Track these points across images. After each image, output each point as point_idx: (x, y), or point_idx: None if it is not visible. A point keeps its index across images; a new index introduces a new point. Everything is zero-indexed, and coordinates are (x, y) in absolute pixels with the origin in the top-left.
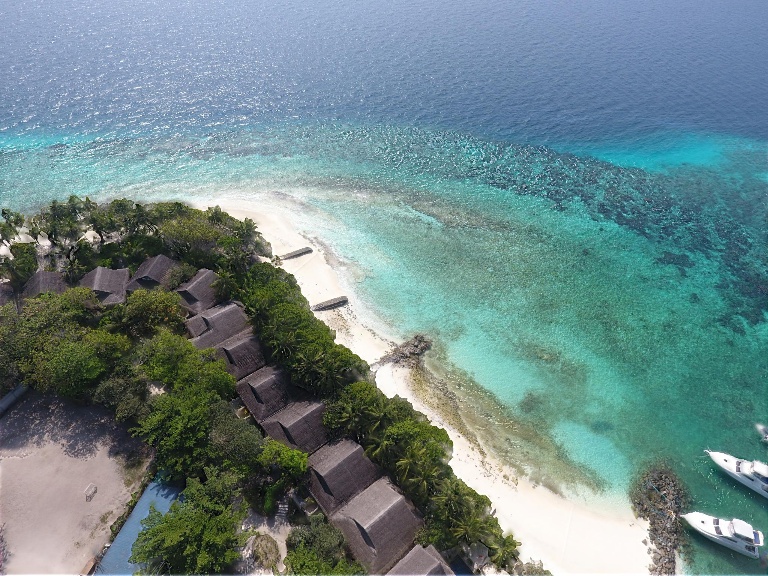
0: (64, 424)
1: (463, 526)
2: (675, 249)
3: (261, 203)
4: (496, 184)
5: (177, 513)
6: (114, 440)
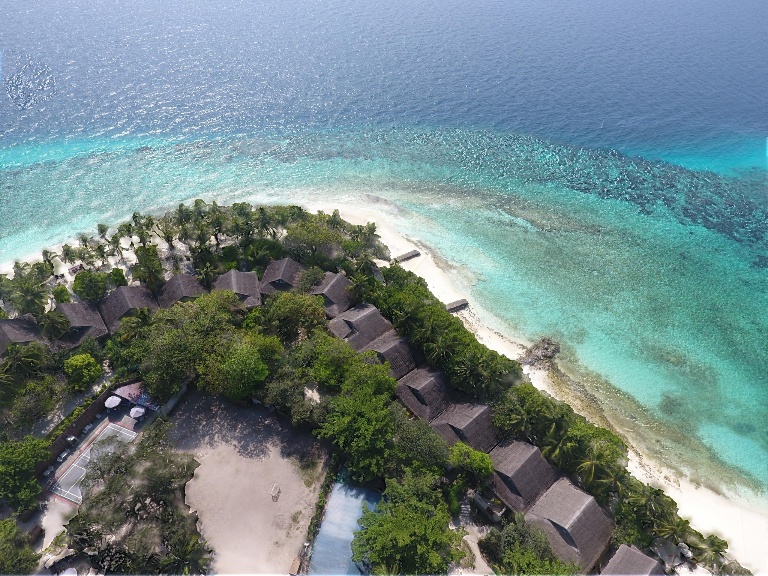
0: (230, 425)
1: (668, 526)
2: (767, 253)
3: (357, 206)
4: (578, 188)
5: (397, 513)
6: (283, 441)
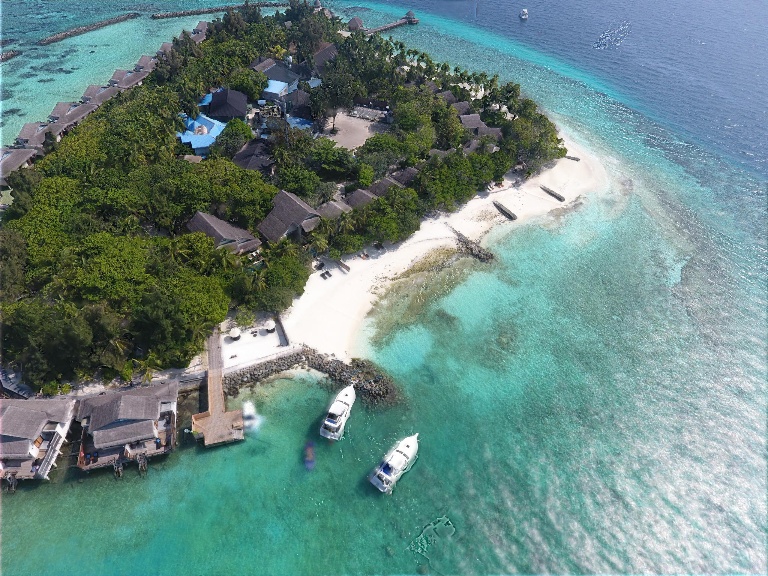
0: None
1: None
2: None
3: (607, 175)
4: None
5: None
6: None
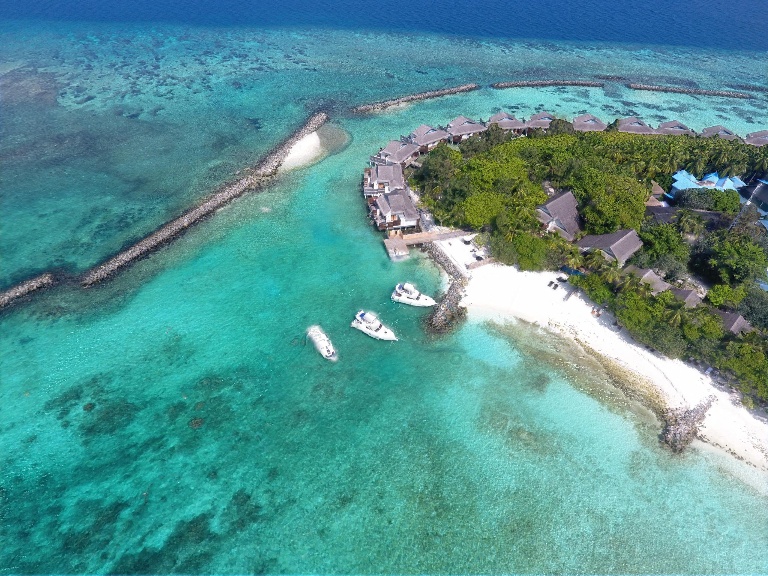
0: None
1: None
2: None
3: None
4: None
5: None
6: None
